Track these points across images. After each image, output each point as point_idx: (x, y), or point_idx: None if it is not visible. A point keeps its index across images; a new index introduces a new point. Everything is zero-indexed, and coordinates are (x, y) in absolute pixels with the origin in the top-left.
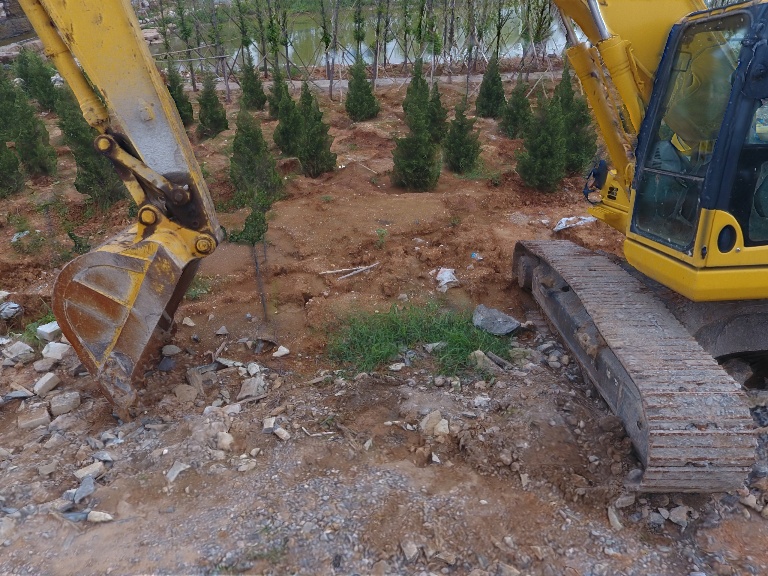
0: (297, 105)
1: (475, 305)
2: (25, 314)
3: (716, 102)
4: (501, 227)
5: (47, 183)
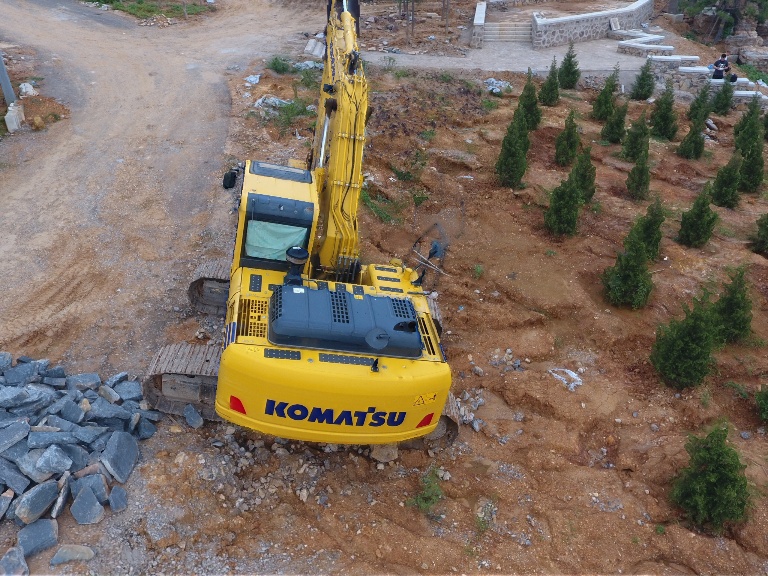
0: (765, 215)
1: None
2: (369, 190)
3: None
4: (539, 334)
5: (551, 168)
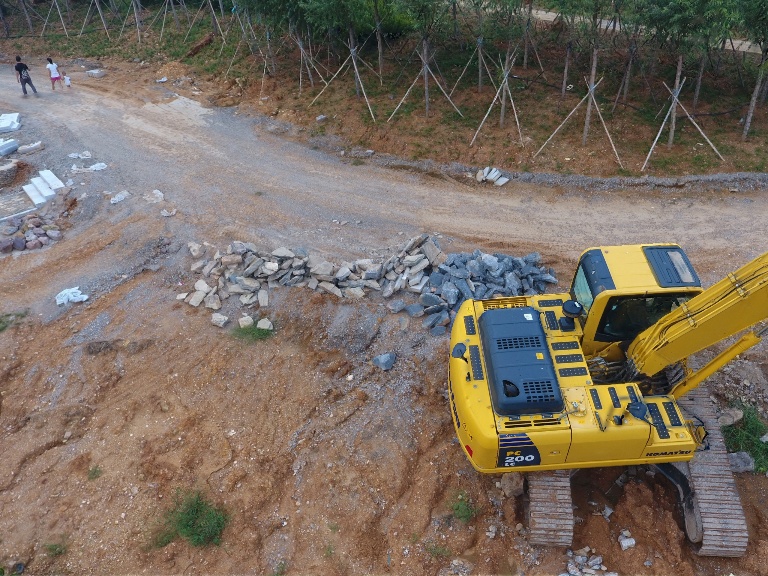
0: None
1: (759, 506)
2: None
3: None
4: None
5: None
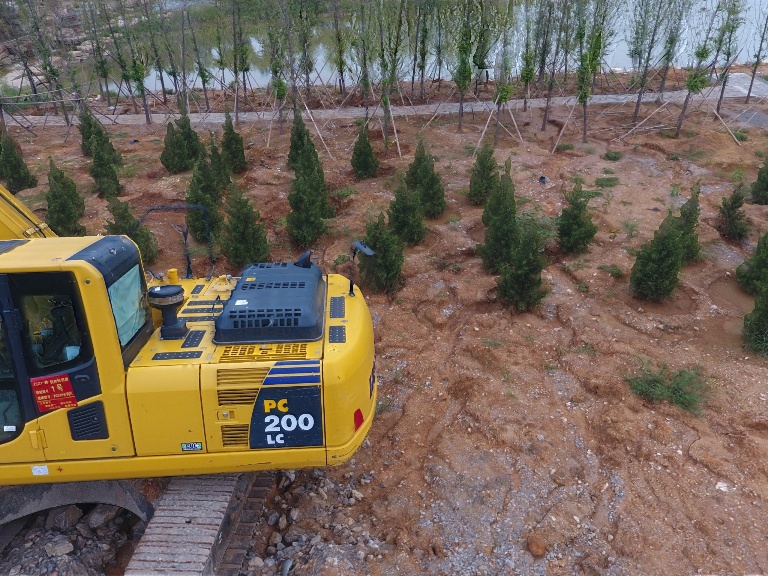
0: (91, 166)
1: None
2: None
3: None
4: None
5: None
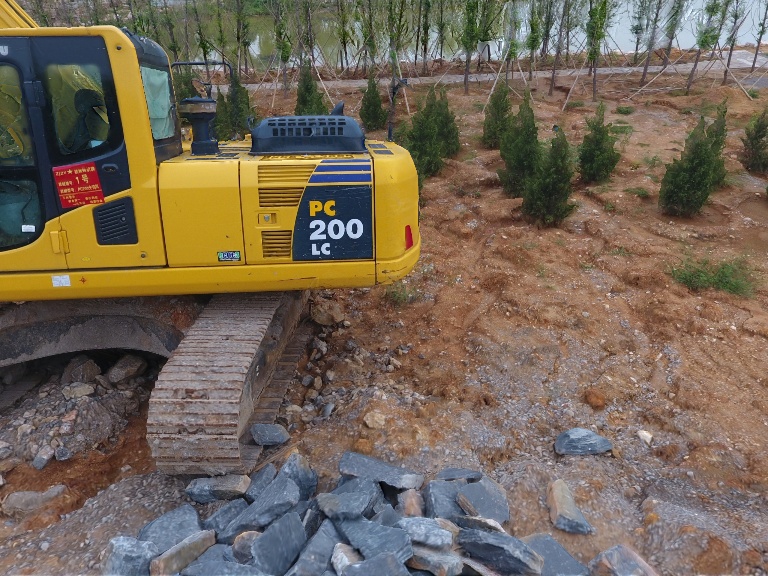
0: None
1: None
2: None
3: (68, 125)
4: None
5: None
